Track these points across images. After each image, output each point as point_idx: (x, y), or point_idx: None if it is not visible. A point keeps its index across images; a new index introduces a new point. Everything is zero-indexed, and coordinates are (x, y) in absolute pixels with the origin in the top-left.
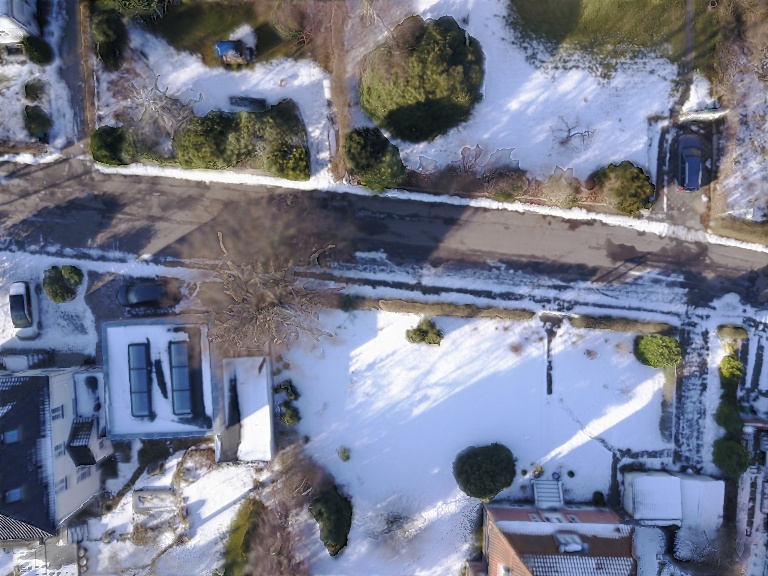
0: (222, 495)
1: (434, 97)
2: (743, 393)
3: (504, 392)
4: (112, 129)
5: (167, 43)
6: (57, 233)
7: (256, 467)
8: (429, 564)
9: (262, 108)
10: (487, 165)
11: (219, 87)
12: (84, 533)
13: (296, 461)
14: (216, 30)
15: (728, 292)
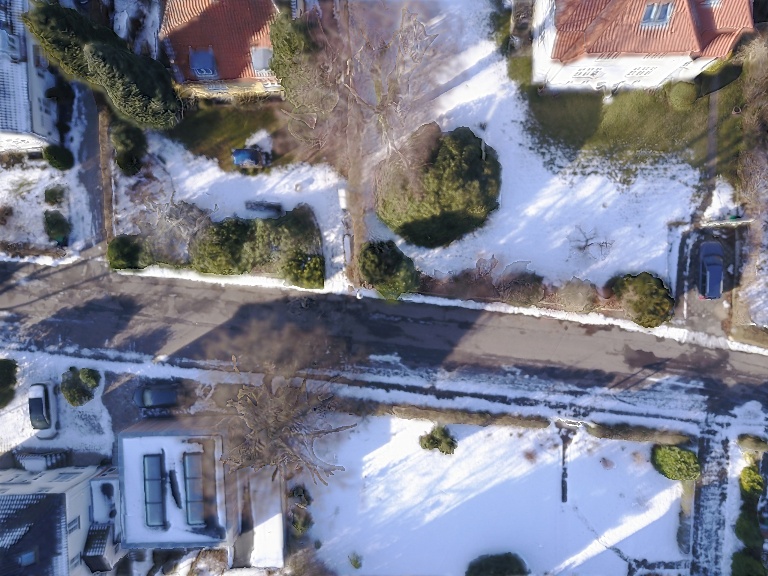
0: None
1: (449, 210)
2: (764, 504)
3: (518, 499)
4: (129, 238)
5: (184, 147)
6: (75, 333)
7: (269, 569)
8: None
9: (277, 213)
10: (503, 276)
11: (235, 191)
12: None
13: (309, 565)
14: (232, 135)
15: (750, 400)
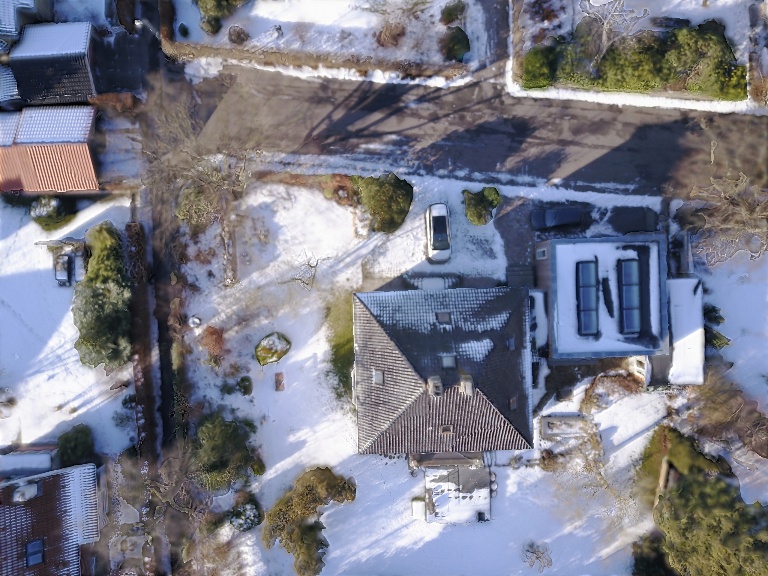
0: (635, 422)
1: None
2: None
3: None
4: (549, 47)
5: None
6: (465, 157)
7: (670, 394)
8: None
9: (685, 28)
10: None
11: (638, 8)
12: (493, 458)
13: (714, 388)
14: None
15: None
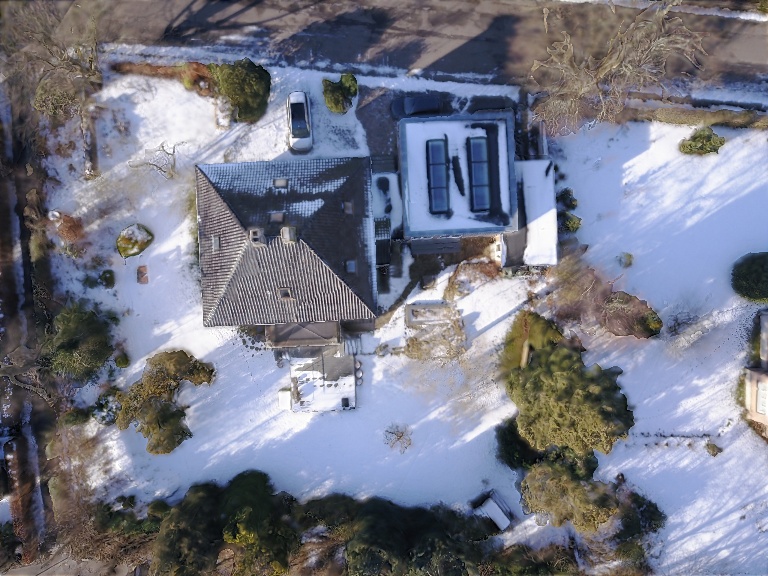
0: (496, 307)
1: None
2: None
3: None
4: None
5: None
6: (327, 48)
7: (530, 279)
8: (707, 371)
9: None
10: None
11: None
12: (358, 347)
13: (572, 272)
14: None
15: None
